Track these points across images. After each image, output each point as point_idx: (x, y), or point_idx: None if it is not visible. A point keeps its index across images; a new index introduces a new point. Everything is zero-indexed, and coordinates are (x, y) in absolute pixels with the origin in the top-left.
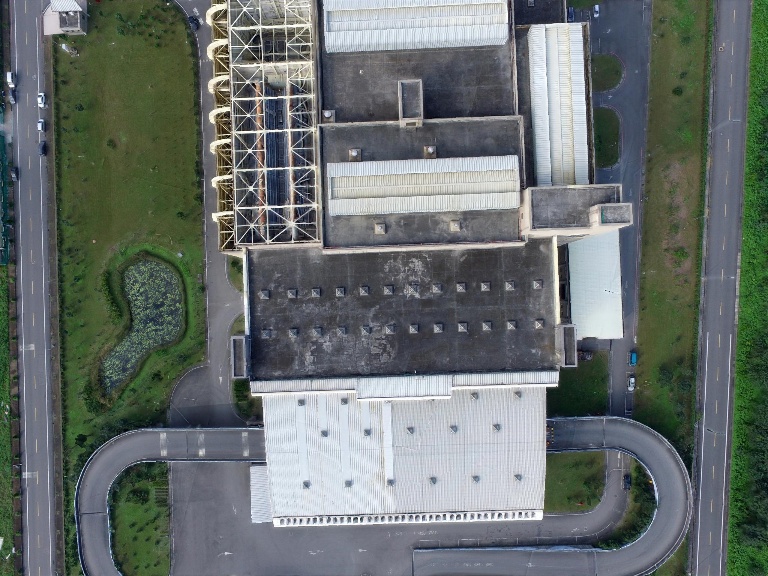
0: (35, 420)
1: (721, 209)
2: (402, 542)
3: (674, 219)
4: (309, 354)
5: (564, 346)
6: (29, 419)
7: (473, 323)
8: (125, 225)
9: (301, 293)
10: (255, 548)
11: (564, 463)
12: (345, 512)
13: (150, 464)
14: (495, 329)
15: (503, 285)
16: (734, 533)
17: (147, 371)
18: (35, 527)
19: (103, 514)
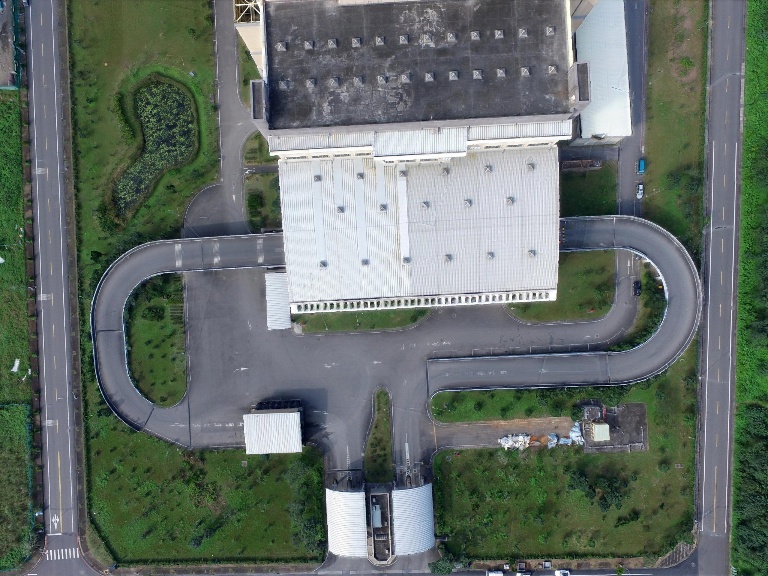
0: (49, 242)
1: (725, 20)
2: (416, 353)
3: (679, 28)
4: (326, 104)
5: (578, 82)
6: (43, 242)
7: (487, 71)
8: (137, 47)
9: (318, 45)
10: (271, 363)
11: (575, 271)
12: (362, 295)
13: (165, 280)
14: (509, 76)
15: (516, 33)
16: (743, 336)
17: (161, 190)
18: (51, 348)
19: (119, 331)
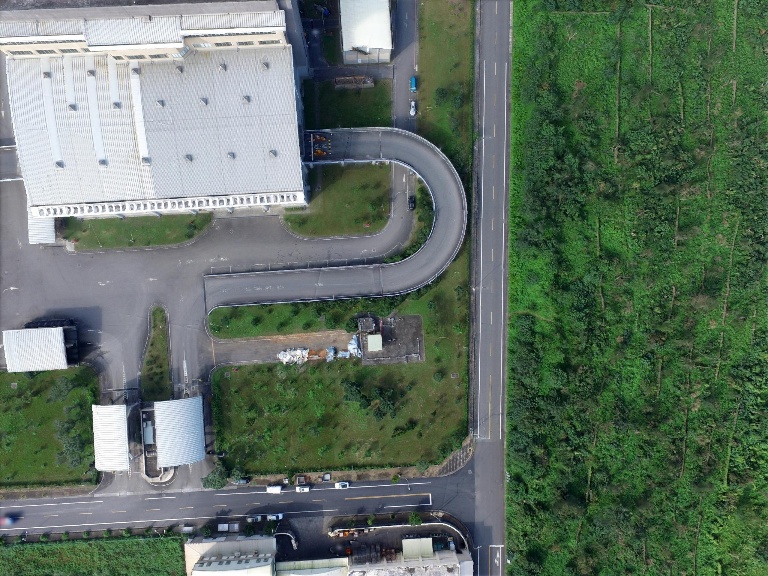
0: None
1: None
2: (193, 270)
3: None
4: None
5: None
6: None
7: None
8: None
9: None
10: (42, 282)
11: (351, 186)
12: (104, 198)
13: None
14: None
15: None
16: (513, 248)
17: None
18: None
19: None
